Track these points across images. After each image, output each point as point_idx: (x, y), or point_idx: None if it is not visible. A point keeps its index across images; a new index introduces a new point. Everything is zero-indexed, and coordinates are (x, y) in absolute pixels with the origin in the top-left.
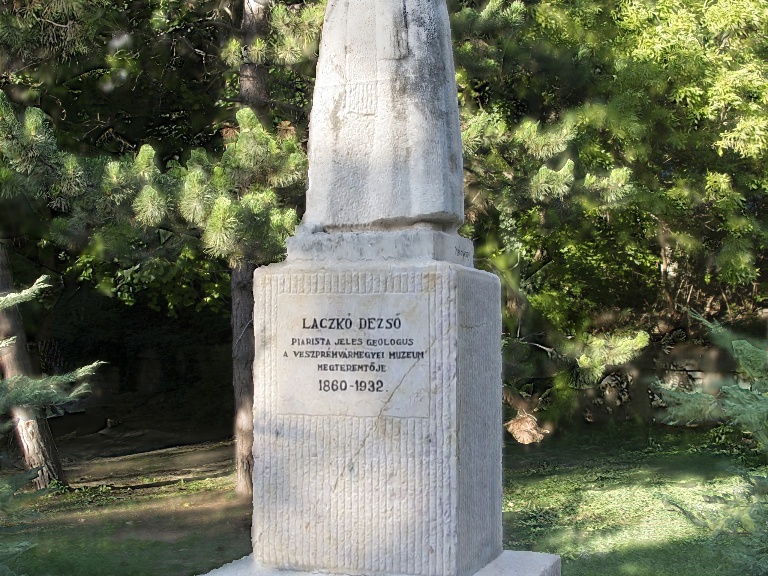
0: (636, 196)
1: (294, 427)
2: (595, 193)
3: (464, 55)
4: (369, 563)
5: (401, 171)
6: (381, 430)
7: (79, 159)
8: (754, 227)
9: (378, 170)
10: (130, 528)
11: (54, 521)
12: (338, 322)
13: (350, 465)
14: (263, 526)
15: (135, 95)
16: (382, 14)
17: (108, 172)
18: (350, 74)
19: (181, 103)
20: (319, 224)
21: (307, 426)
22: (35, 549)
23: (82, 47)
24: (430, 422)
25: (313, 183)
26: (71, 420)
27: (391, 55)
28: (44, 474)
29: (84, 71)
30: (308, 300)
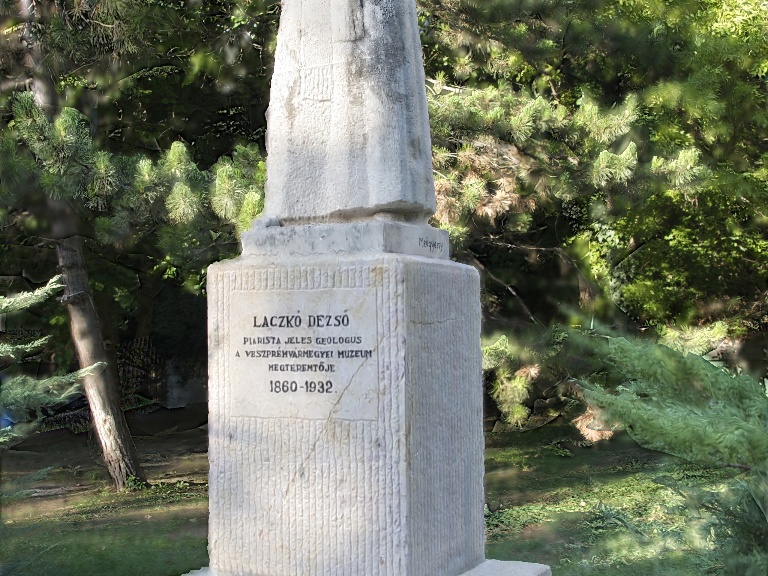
0: (719, 178)
1: (247, 430)
2: (662, 176)
3: (519, 37)
4: (321, 573)
5: (358, 159)
6: (330, 433)
7: (117, 158)
8: None
9: (335, 159)
10: (193, 525)
11: (122, 517)
12: (288, 320)
13: (301, 470)
14: (219, 533)
15: (204, 93)
16: None
17: (140, 170)
18: (305, 59)
19: (238, 99)
20: (275, 217)
21: (260, 429)
22: (90, 546)
23: (131, 46)
24: (379, 425)
25: (270, 174)
26: (173, 416)
27: (347, 37)
28: (122, 470)
29: (136, 70)
30: (259, 297)
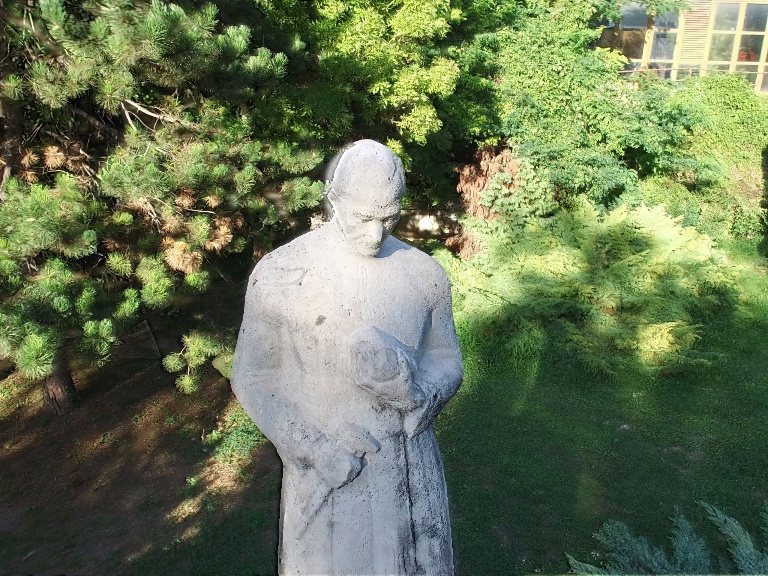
0: None
1: None
2: None
3: None
4: None
5: None
6: None
7: None
8: (408, 165)
9: None
10: None
11: None
12: None
13: None
14: None
15: None
16: (383, 531)
17: None
18: None
19: None
20: None
21: None
22: None
23: None
24: None
25: None
26: None
27: None
28: None
29: None
30: None
